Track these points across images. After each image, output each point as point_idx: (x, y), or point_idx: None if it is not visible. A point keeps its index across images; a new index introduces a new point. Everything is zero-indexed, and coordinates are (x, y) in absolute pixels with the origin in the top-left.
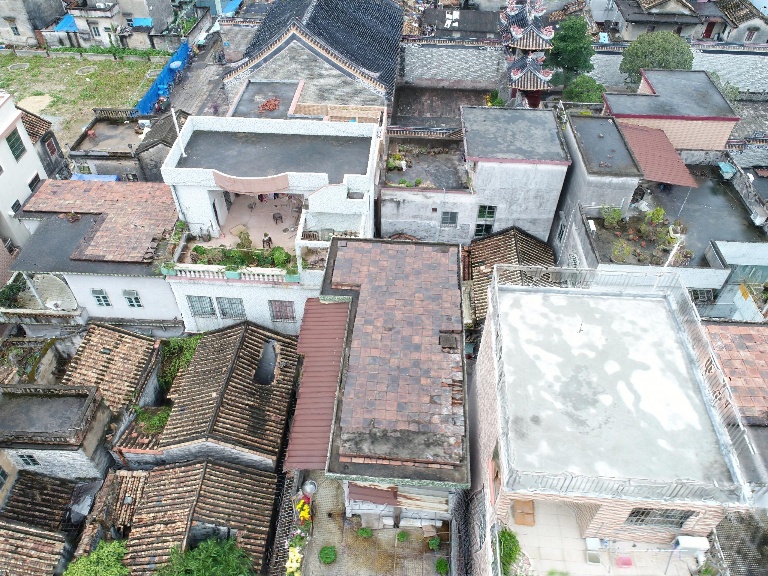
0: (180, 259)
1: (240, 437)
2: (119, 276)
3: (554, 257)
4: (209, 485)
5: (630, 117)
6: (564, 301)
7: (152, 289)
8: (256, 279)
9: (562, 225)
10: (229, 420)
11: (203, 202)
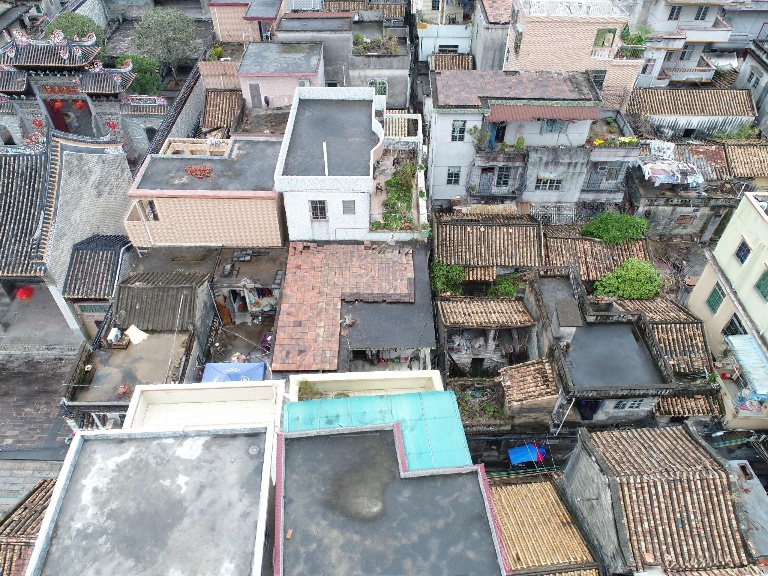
0: None
1: None
2: None
3: None
4: None
5: None
6: (527, 5)
7: None
8: None
9: None
10: None
11: None
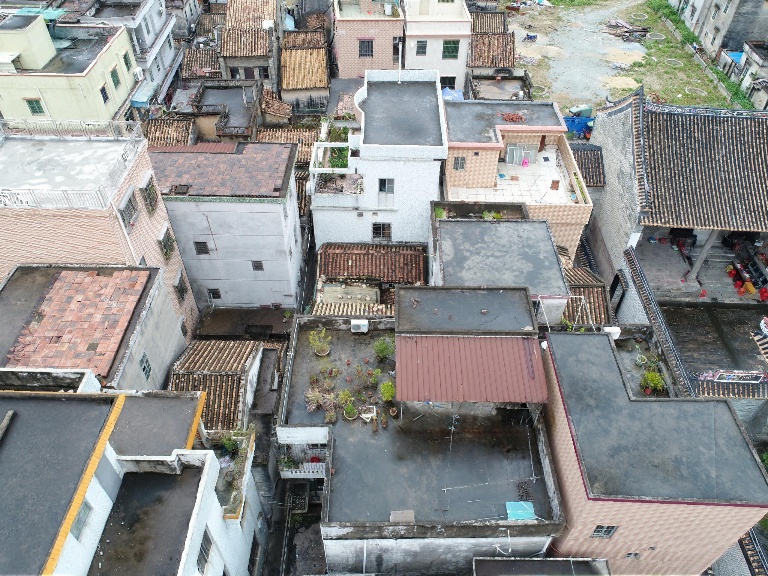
0: None
1: None
2: None
3: None
4: None
5: None
6: None
7: None
8: None
9: None
10: None
11: None
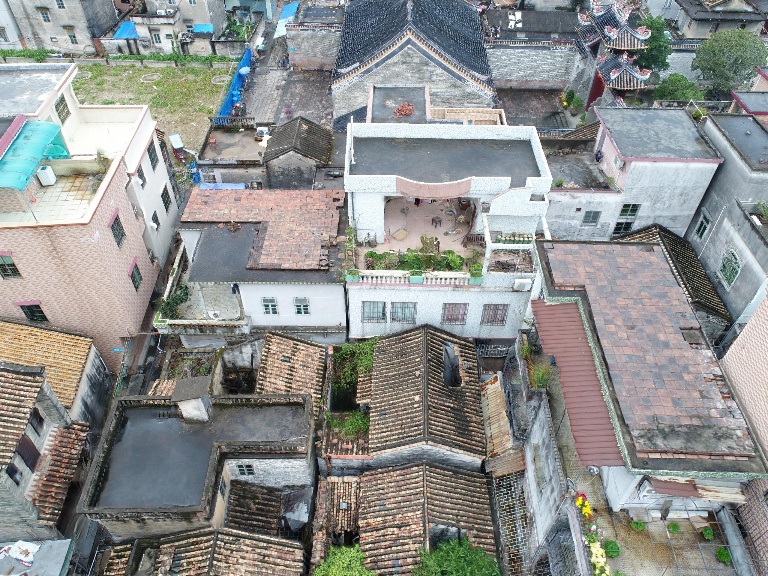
0: (354, 265)
1: (453, 439)
2: (297, 284)
3: (695, 252)
4: (433, 487)
5: (766, 114)
6: None
7: (324, 296)
8: (438, 283)
9: (704, 221)
10: (439, 423)
11: (377, 208)
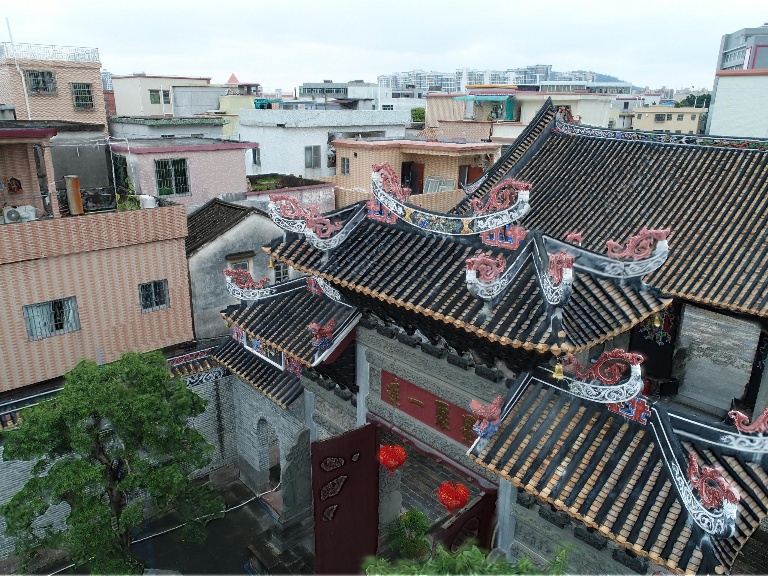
0: None
1: None
2: None
3: None
4: None
5: None
6: None
7: None
8: None
9: None
10: None
11: None
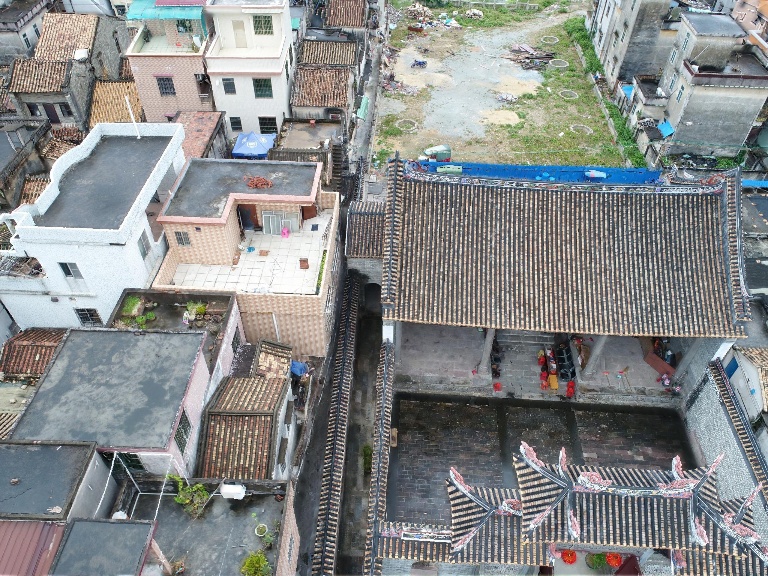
0: None
1: None
2: None
3: None
4: None
5: None
6: None
7: None
8: None
9: None
10: None
11: None
